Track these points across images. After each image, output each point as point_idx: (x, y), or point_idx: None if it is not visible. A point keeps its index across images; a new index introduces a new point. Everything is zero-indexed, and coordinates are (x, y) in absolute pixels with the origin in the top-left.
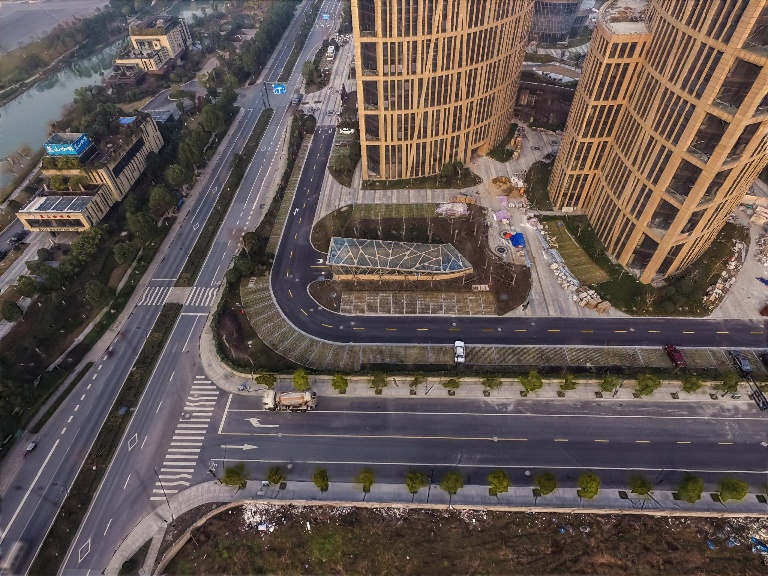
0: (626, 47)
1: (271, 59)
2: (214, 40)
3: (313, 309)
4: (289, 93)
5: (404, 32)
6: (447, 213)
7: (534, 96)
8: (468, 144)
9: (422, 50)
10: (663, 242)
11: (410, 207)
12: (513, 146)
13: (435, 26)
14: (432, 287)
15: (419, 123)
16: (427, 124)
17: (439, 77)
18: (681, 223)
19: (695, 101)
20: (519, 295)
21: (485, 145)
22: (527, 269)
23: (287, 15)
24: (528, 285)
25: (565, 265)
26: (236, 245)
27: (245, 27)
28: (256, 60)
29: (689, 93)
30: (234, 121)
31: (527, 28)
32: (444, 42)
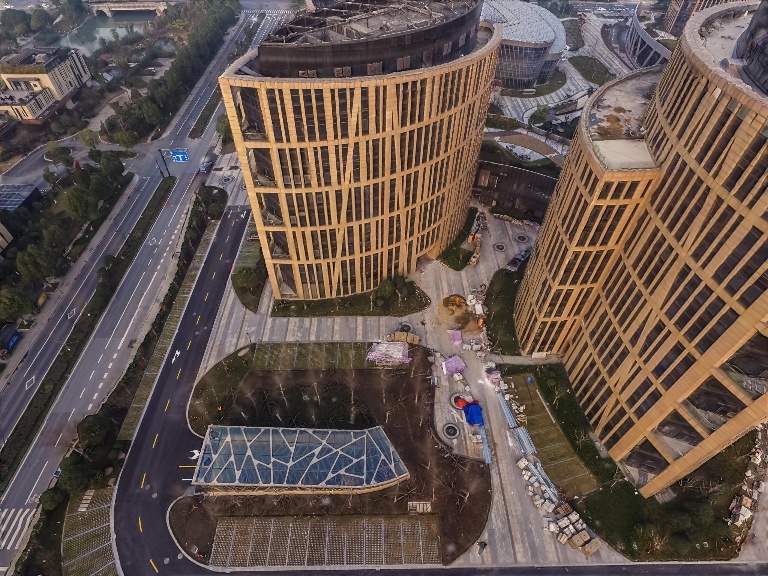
0: (623, 186)
1: (186, 102)
2: (122, 72)
3: (169, 559)
4: (201, 153)
5: (307, 136)
6: (381, 361)
7: (496, 177)
8: (412, 253)
9: (337, 157)
10: (676, 465)
11: (332, 349)
12: (471, 243)
13: (352, 127)
14: (350, 508)
15: (342, 239)
16: (353, 239)
17: (365, 187)
18: (706, 456)
19: (738, 308)
20: (474, 523)
21: (435, 248)
22: (486, 468)
23: (212, 44)
24: (487, 501)
25: (537, 459)
26: (81, 419)
27: (163, 56)
28: (163, 107)
29: (728, 291)
30: (122, 196)
31: (485, 108)
32: (368, 146)
